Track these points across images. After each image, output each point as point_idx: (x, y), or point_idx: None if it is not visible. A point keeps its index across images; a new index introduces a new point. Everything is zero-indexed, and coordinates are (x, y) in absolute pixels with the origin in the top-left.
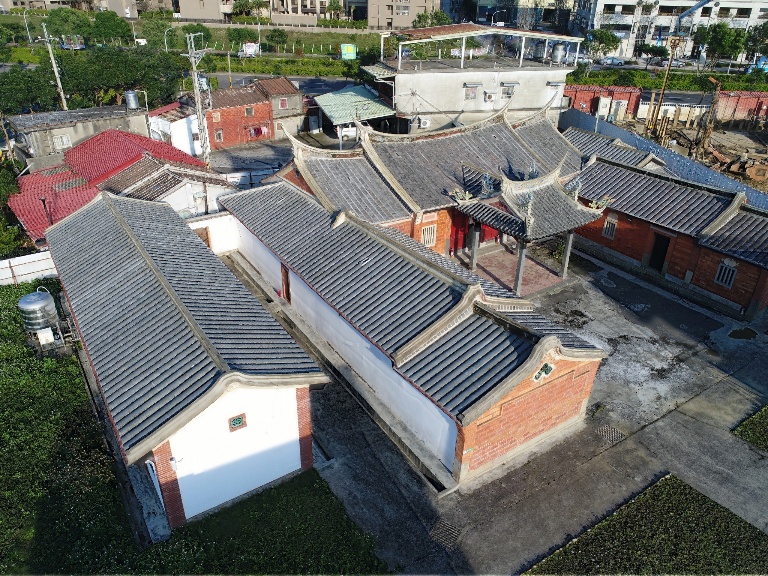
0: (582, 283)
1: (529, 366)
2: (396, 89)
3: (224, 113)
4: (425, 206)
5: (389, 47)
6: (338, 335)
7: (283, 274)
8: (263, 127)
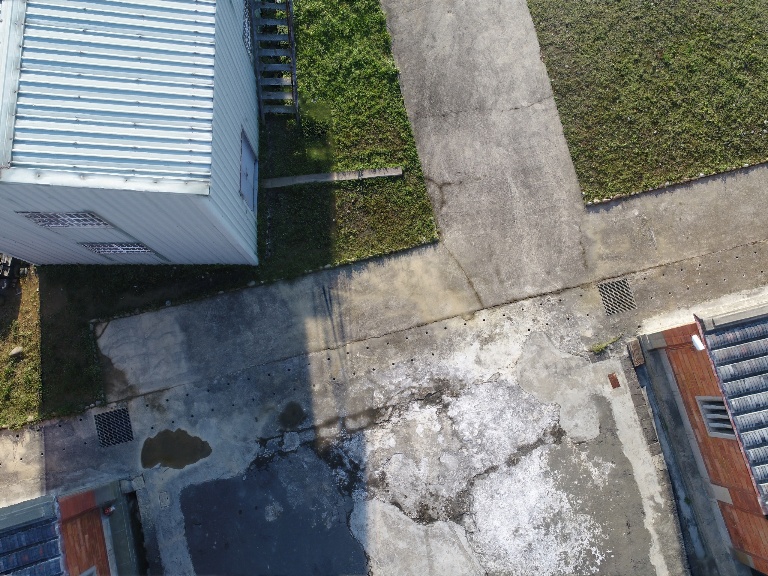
0: None
1: None
2: None
3: None
4: None
5: None
6: None
7: None
8: None
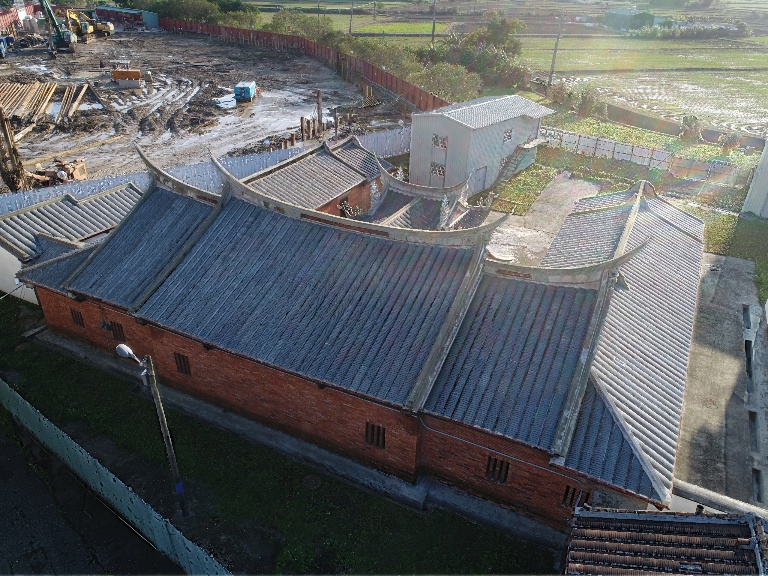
0: None
1: None
2: None
3: None
4: None
5: None
6: None
7: None
8: None
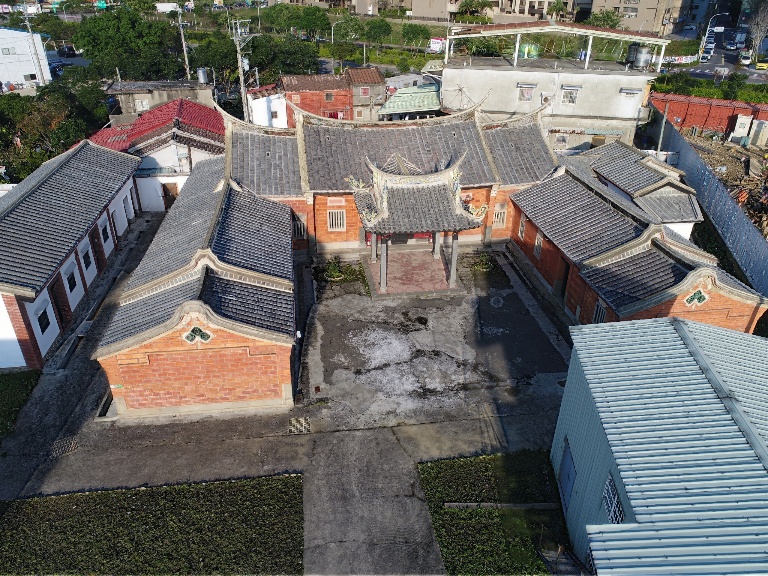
0: (468, 296)
1: (169, 323)
2: (443, 84)
3: (304, 96)
4: (316, 188)
5: (460, 42)
6: None
7: None
8: (340, 112)
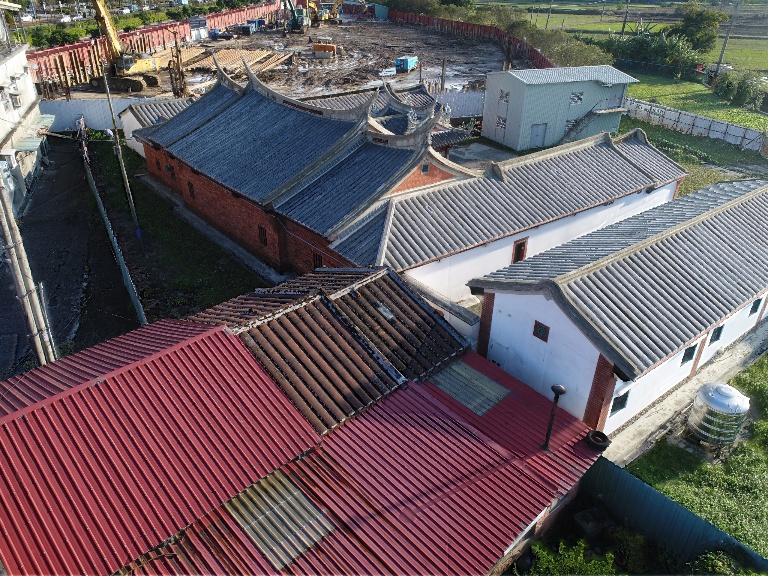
0: None
1: None
2: None
3: None
4: None
5: None
6: (591, 231)
7: (514, 253)
8: None
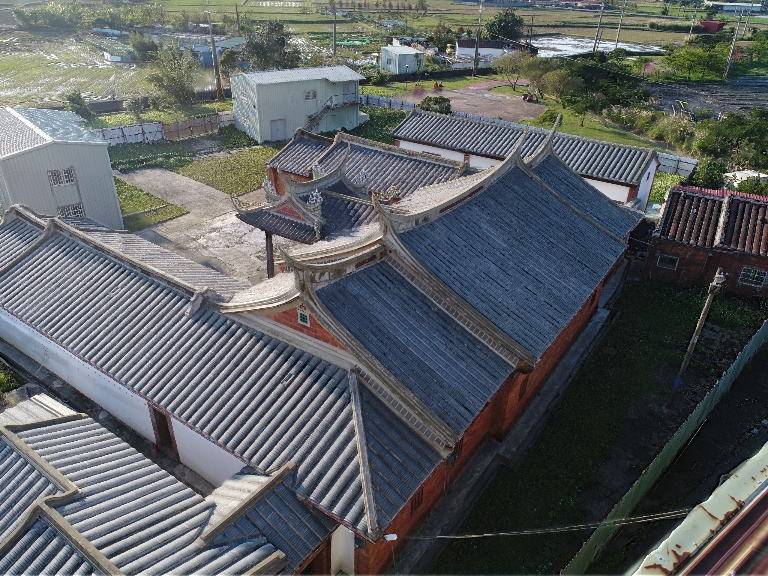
0: None
1: None
2: None
3: None
4: (417, 191)
5: None
6: None
7: None
8: None
